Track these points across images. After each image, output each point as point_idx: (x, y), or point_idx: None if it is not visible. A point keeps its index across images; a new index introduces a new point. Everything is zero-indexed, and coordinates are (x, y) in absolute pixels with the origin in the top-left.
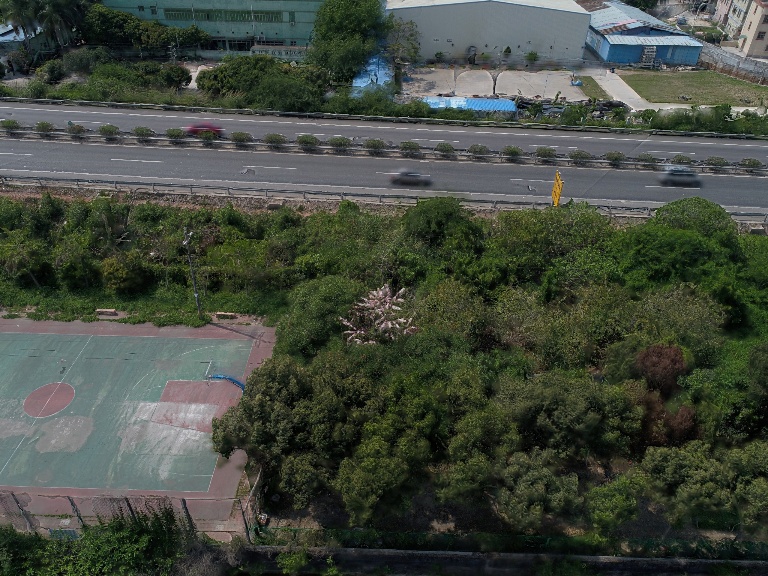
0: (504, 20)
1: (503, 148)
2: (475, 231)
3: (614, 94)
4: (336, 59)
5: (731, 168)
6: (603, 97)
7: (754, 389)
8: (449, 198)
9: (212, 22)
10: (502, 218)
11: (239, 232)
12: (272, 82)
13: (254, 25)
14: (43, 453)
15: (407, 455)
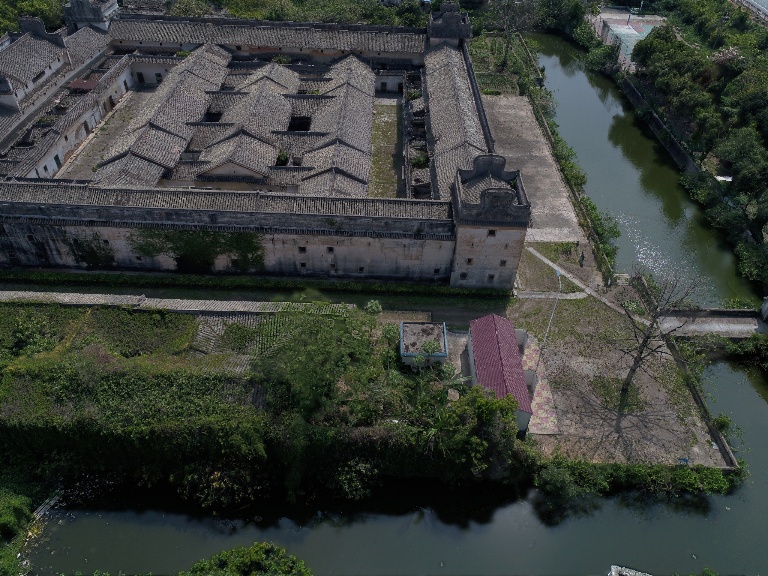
0: None
1: None
2: None
3: None
4: None
5: None
6: None
7: None
8: None
9: None
10: None
11: None
12: None
13: None
14: None
15: (652, 44)
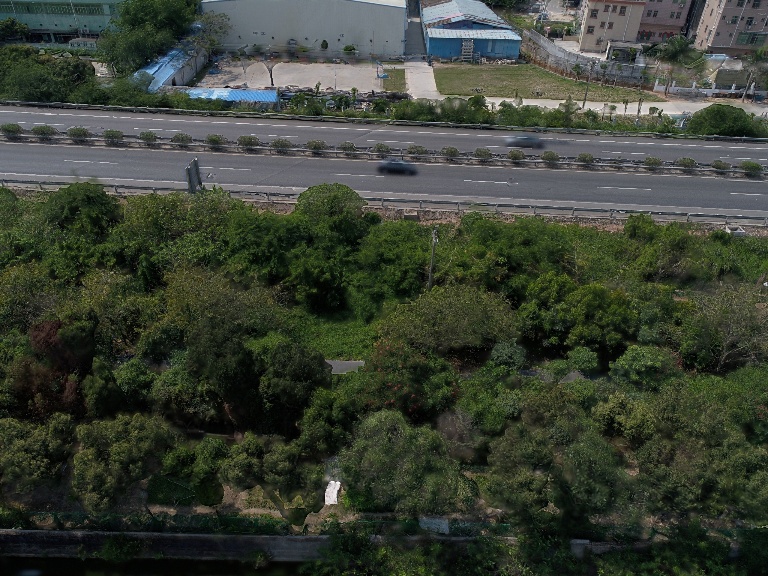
0: (320, 13)
1: (207, 137)
2: (120, 217)
3: (412, 86)
4: (122, 51)
5: (430, 156)
6: (399, 89)
7: (186, 365)
8: (84, 184)
9: (33, 15)
10: (128, 203)
11: None
12: (20, 72)
13: (76, 18)
14: None
15: None
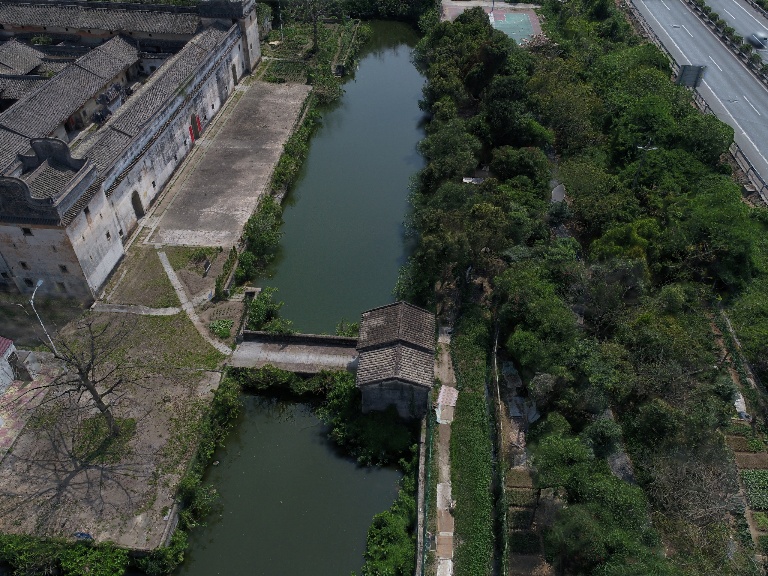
0: None
1: None
2: None
3: None
4: None
5: None
6: None
7: None
8: None
9: None
10: None
11: (595, 22)
12: None
13: None
14: None
15: (445, 28)
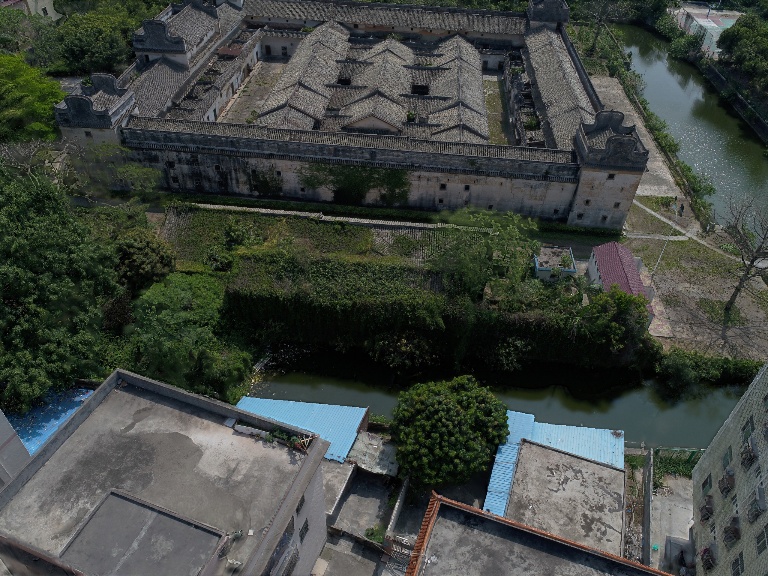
0: None
1: None
2: None
3: None
4: None
5: None
6: None
7: None
8: None
9: None
10: None
11: None
12: None
13: None
14: None
15: (739, 32)
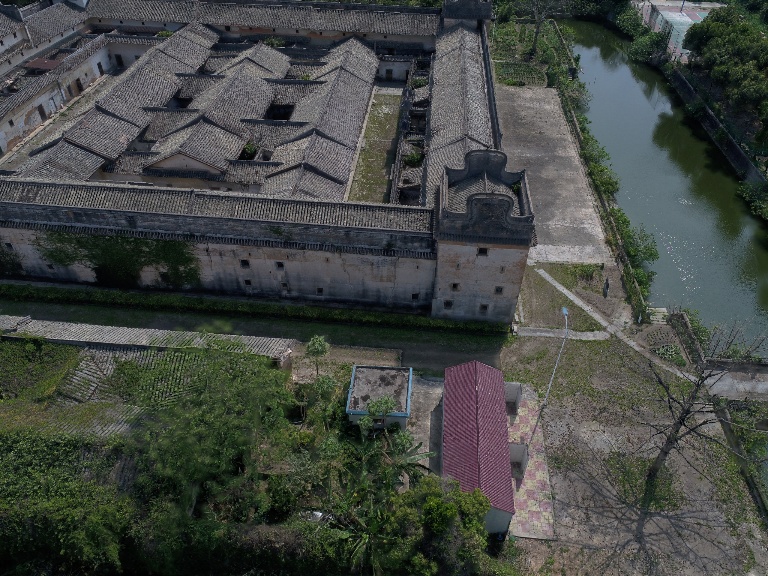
0: None
1: None
2: None
3: None
4: None
5: None
6: None
7: None
8: None
9: None
10: None
11: None
12: None
13: None
14: (681, 35)
15: (709, 28)
